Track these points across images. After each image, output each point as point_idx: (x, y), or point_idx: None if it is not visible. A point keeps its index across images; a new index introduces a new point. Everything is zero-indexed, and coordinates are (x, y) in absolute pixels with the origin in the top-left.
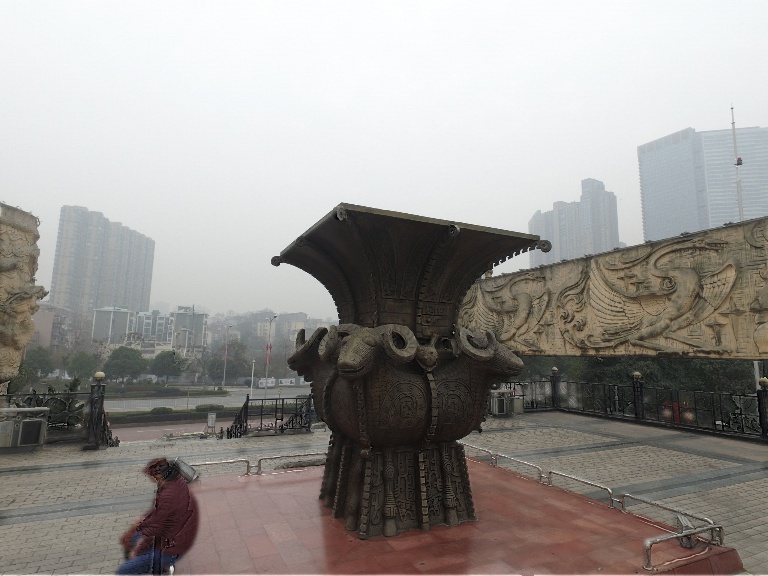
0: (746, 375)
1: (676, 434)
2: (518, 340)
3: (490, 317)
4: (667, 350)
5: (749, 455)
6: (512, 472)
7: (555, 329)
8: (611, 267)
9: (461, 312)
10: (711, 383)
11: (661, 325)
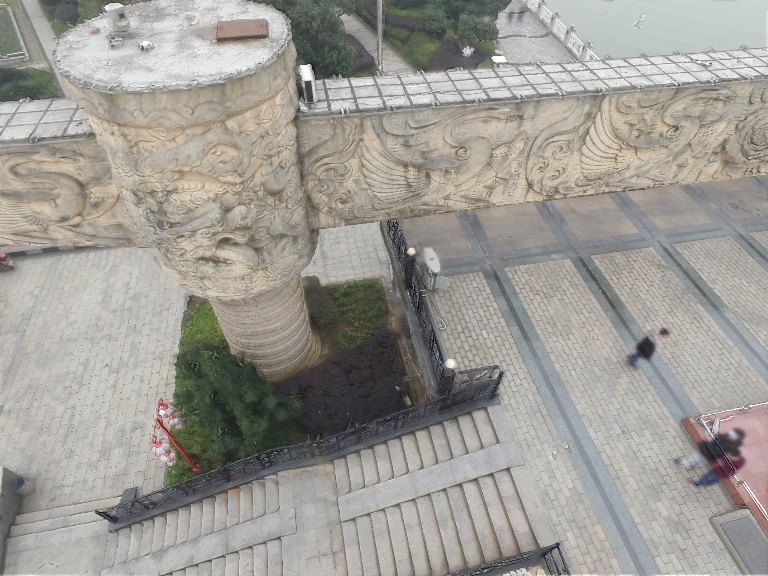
0: (337, 24)
1: (539, 211)
2: (456, 198)
3: (399, 174)
4: (637, 187)
5: (620, 226)
6: (761, 408)
7: (520, 180)
8: (628, 111)
9: (315, 170)
10: (317, 44)
11: (646, 169)
